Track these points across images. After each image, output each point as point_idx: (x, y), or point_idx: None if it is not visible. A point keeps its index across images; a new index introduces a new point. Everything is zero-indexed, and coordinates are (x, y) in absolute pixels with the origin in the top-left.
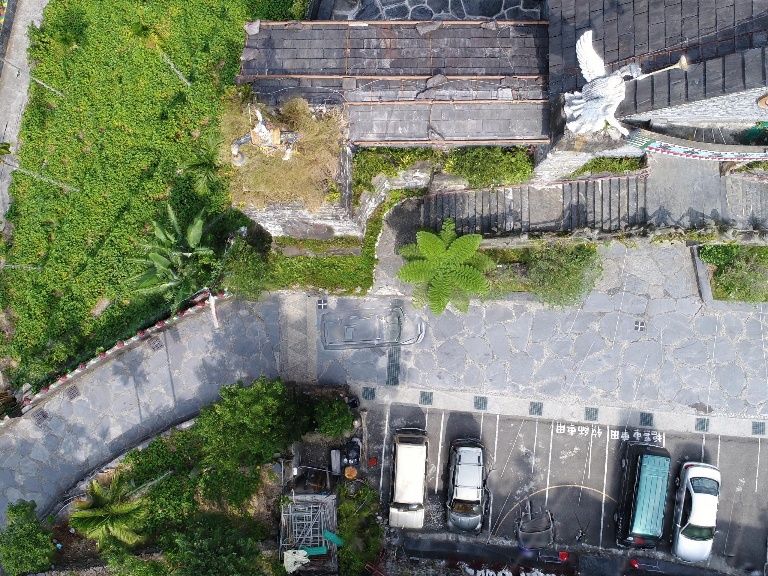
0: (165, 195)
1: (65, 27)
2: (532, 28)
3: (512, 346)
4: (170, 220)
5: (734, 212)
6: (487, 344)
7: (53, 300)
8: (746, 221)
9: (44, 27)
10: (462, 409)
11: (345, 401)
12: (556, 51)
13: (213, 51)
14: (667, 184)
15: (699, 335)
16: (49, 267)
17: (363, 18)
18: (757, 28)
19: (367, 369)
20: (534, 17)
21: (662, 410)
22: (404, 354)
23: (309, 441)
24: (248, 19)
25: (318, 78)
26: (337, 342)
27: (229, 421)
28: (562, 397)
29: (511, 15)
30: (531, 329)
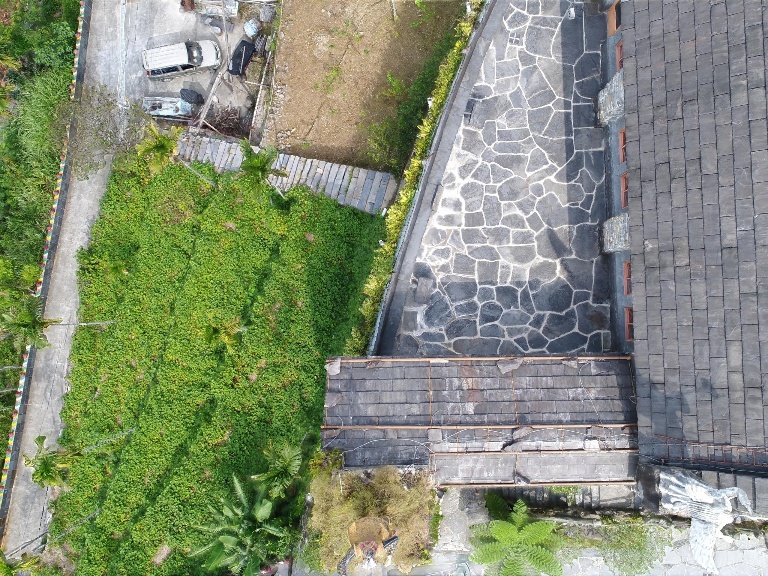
0: (223, 439)
1: (113, 247)
2: (613, 364)
3: None
4: (237, 493)
5: None
6: None
7: (112, 543)
8: None
9: (92, 247)
10: None
11: None
12: (645, 412)
13: (268, 294)
14: None
15: None
16: (107, 508)
17: (433, 314)
18: None
19: None
20: (604, 312)
21: None
22: None
23: None
24: (303, 262)
25: (403, 428)
26: None
27: None
28: None
29: (581, 310)
30: None
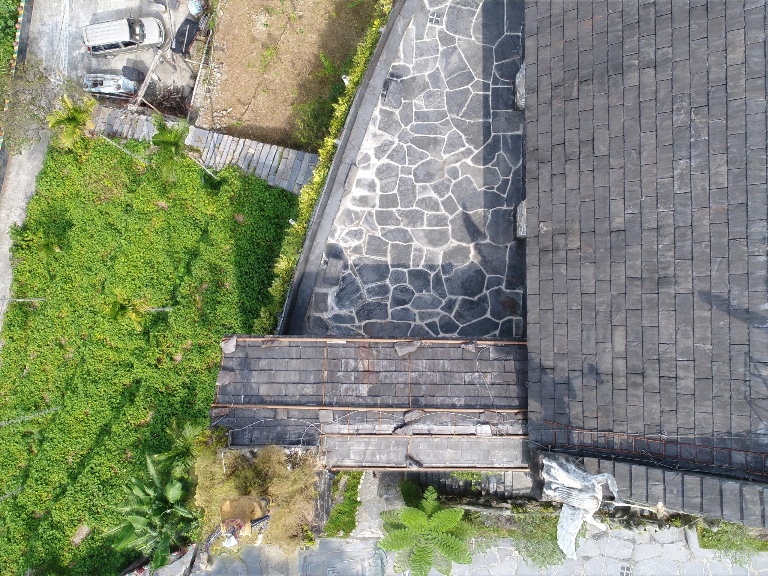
0: (146, 420)
1: (48, 224)
2: (512, 349)
3: None
4: (149, 473)
5: None
6: None
7: (33, 522)
8: None
9: (27, 224)
10: None
11: None
12: (535, 398)
13: (196, 274)
14: None
15: None
16: (29, 487)
17: (344, 296)
18: (736, 446)
19: None
20: (517, 298)
21: None
22: None
23: None
24: (231, 243)
25: (294, 409)
26: None
27: None
28: None
29: (493, 295)
30: (515, 573)
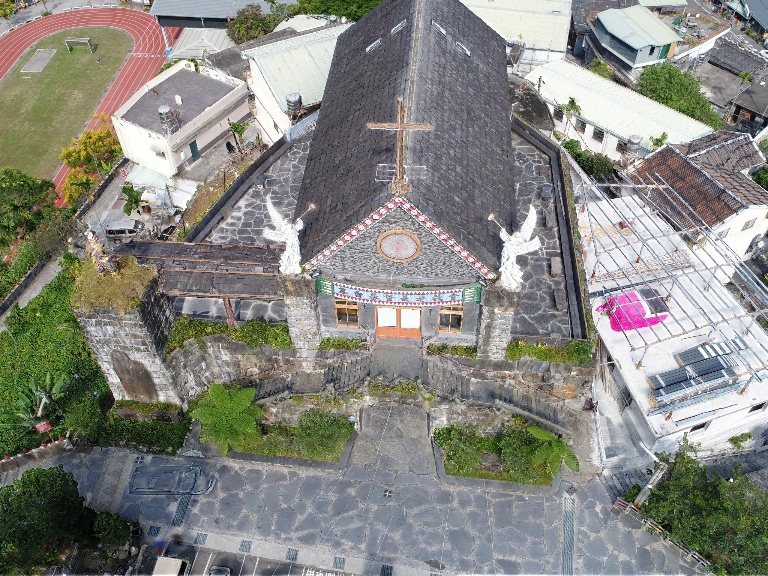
0: None
1: None
2: None
3: (282, 502)
4: (45, 381)
5: (435, 383)
6: (262, 499)
7: None
8: (446, 393)
9: (25, 309)
10: (229, 550)
11: (130, 529)
12: None
13: None
14: (385, 359)
15: (436, 504)
16: None
17: None
18: None
19: (159, 511)
20: None
21: (401, 564)
22: (192, 502)
23: (89, 567)
24: None
25: (152, 258)
26: (141, 489)
27: (20, 493)
28: (316, 547)
29: None
30: (300, 490)
